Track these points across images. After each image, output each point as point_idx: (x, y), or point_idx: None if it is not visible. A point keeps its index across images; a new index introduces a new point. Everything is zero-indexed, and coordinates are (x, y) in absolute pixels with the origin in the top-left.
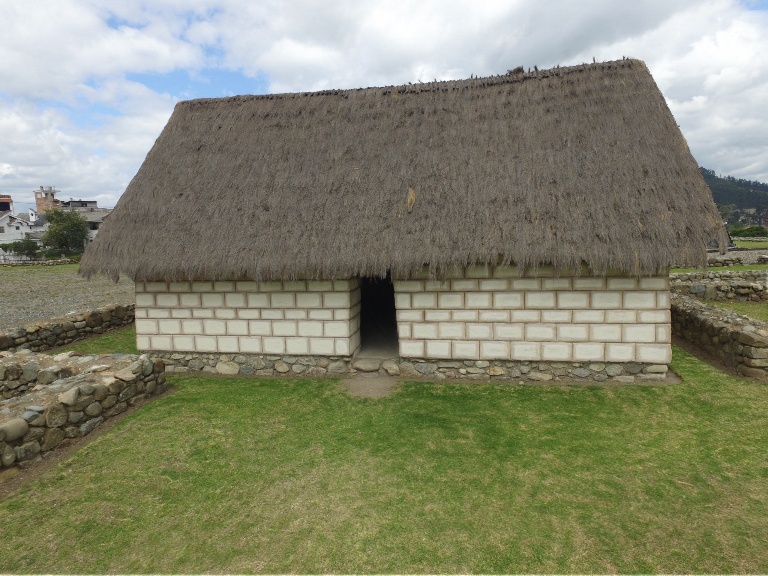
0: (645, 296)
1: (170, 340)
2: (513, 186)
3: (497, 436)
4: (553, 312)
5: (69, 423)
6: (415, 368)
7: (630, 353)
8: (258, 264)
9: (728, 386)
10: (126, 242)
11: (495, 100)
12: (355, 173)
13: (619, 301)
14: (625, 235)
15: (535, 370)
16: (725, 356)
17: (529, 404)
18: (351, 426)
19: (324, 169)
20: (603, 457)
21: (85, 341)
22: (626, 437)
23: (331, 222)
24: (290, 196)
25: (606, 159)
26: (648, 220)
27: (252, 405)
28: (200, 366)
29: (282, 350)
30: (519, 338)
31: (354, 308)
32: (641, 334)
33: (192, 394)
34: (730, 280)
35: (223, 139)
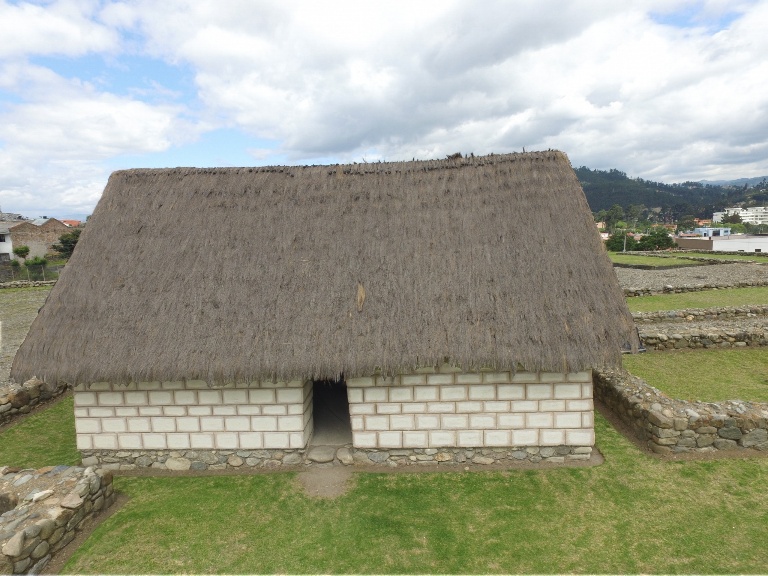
0: (572, 388)
1: (115, 439)
2: (455, 284)
3: (448, 542)
4: (494, 403)
5: (15, 574)
6: (368, 457)
7: (560, 438)
8: (210, 368)
9: (641, 466)
10: (63, 343)
11: (436, 187)
12: (305, 265)
13: (550, 392)
14: (554, 338)
15: (479, 455)
16: (638, 429)
17: (475, 496)
18: (311, 540)
19: (273, 260)
20: (541, 563)
21: (12, 426)
22: (559, 535)
23: (283, 322)
24: (240, 290)
25: (536, 258)
26: (573, 322)
27: (209, 518)
28: (148, 463)
29: (235, 445)
30: (464, 427)
31: (307, 399)
32: (569, 421)
33: (144, 505)
34: (641, 321)
35: (165, 220)
